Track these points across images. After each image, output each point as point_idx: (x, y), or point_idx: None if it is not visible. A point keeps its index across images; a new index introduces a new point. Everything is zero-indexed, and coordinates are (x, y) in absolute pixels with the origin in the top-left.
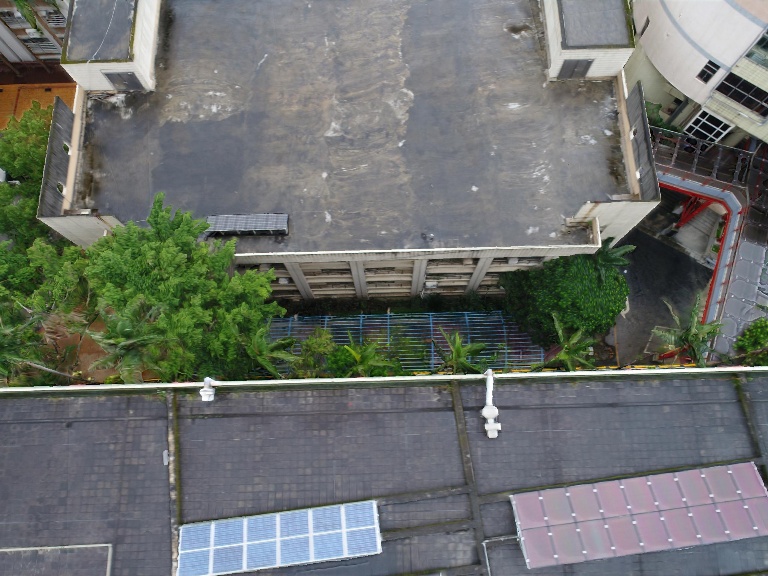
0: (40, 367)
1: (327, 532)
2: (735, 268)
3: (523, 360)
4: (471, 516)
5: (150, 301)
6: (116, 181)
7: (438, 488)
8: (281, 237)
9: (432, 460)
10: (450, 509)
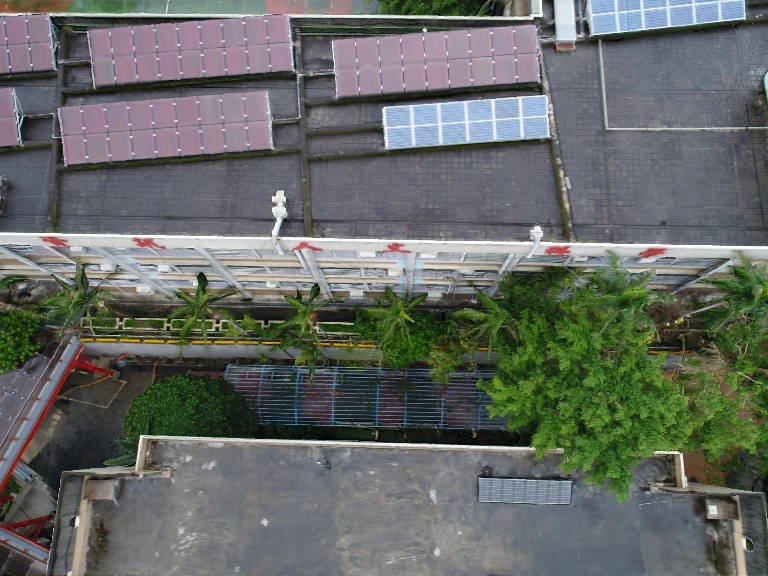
0: (712, 306)
1: (427, 125)
2: (8, 439)
3: (246, 371)
4: (308, 139)
5: (612, 363)
6: (686, 560)
7: (333, 159)
8: (486, 474)
9: (336, 181)
10: (325, 144)
